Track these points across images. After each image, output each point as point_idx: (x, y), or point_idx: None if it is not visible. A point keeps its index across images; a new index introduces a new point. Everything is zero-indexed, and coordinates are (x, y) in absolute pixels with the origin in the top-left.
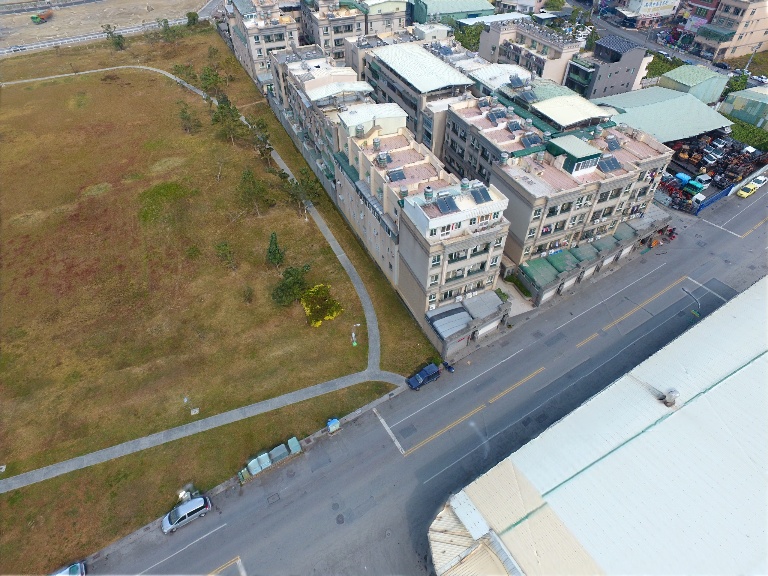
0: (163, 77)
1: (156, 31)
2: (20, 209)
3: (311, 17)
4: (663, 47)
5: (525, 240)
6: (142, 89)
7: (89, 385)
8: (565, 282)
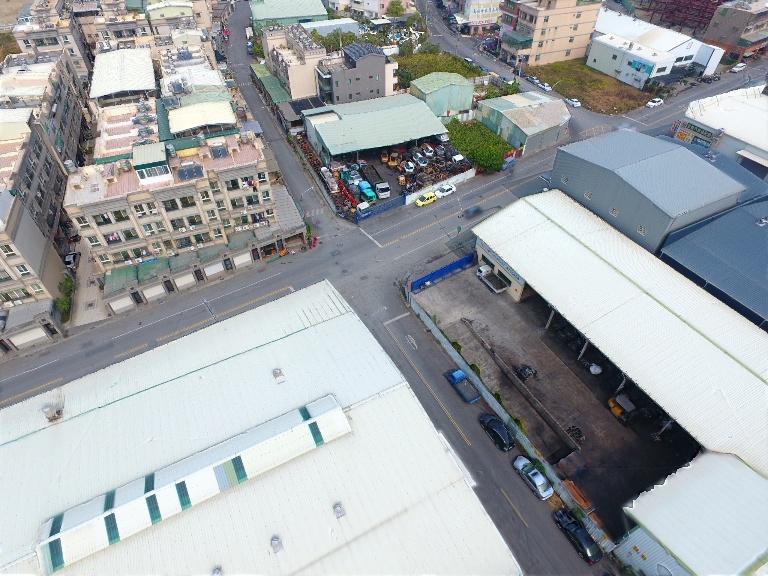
0: None
1: None
2: None
3: None
4: (480, 54)
5: (90, 248)
6: None
7: None
8: (140, 291)
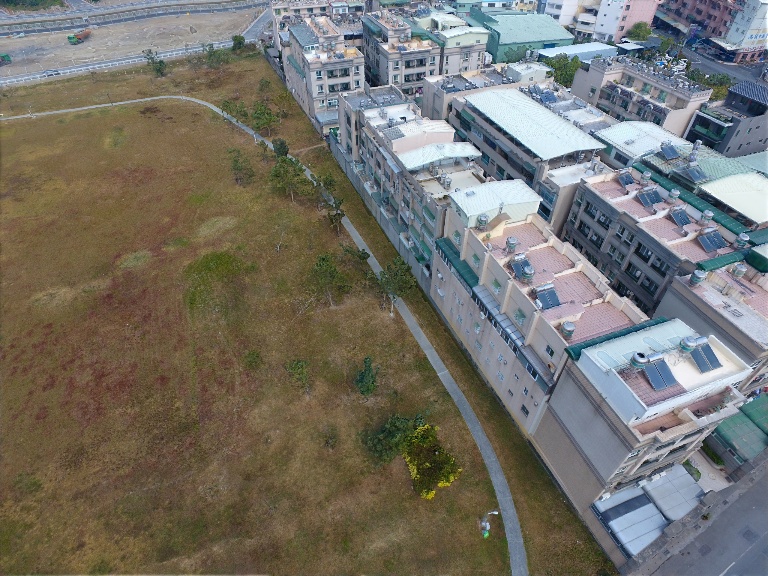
0: (208, 111)
1: (200, 56)
2: (43, 284)
3: (379, 49)
4: None
5: None
6: (185, 125)
7: None
8: None
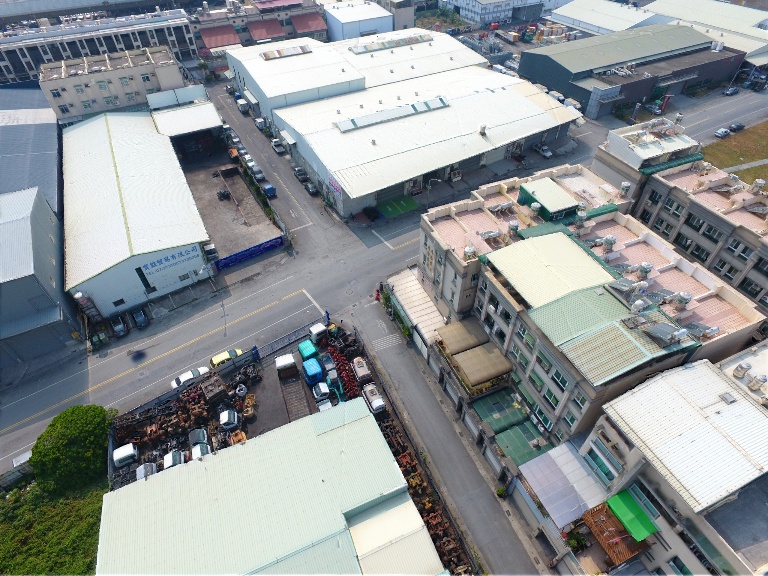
0: None
1: None
2: None
3: None
4: None
5: None
6: None
7: None
8: None
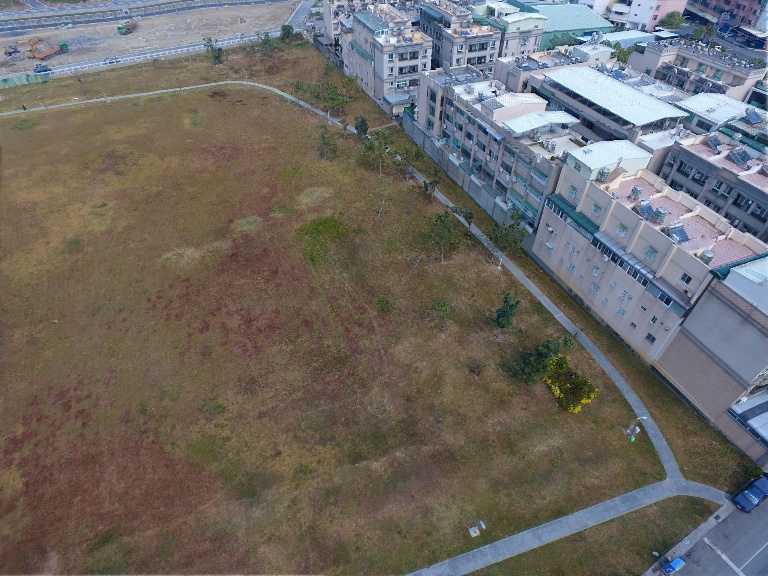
0: (274, 94)
1: (253, 44)
2: (169, 246)
3: (442, 34)
4: None
5: None
6: (256, 107)
7: (325, 485)
8: None
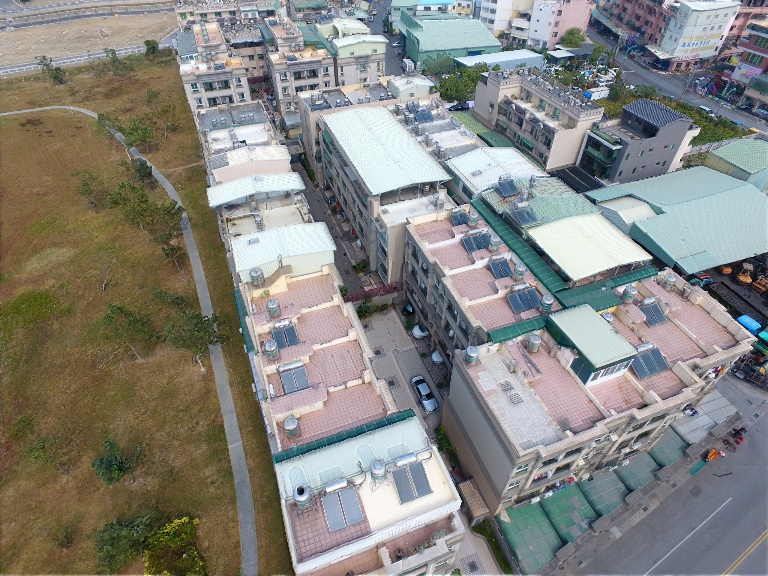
0: (94, 123)
1: (105, 62)
2: None
3: (268, 58)
4: (704, 98)
5: (503, 493)
6: (62, 140)
7: None
8: (569, 558)
